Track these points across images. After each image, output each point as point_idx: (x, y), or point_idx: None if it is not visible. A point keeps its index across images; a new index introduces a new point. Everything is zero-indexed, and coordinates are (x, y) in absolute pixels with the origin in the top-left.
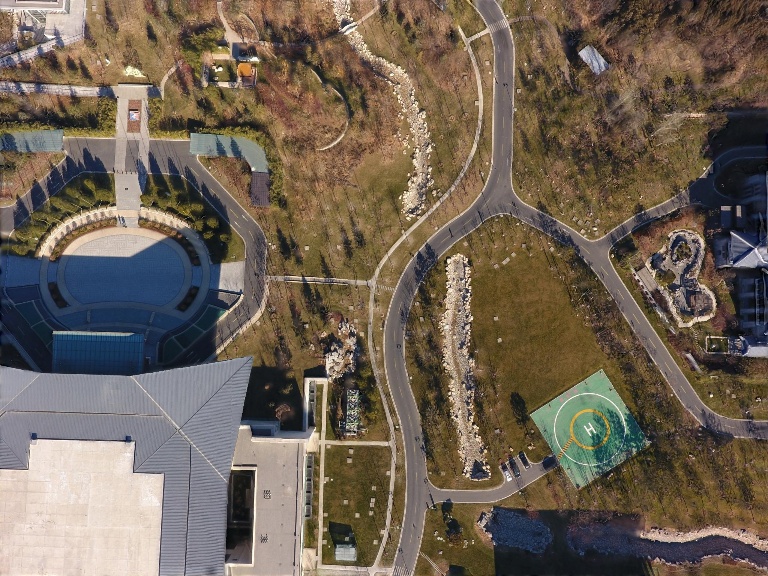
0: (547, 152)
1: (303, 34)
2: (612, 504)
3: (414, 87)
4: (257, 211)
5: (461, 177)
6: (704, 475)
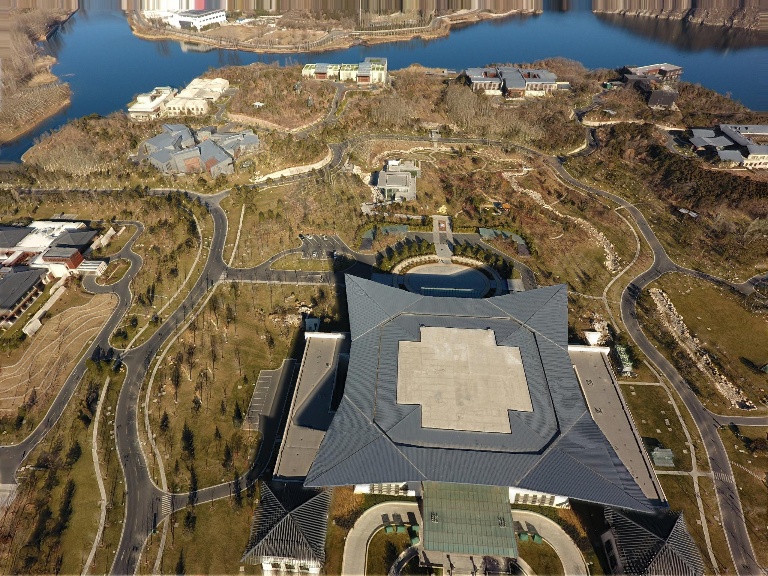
0: (684, 247)
1: None
2: None
3: (591, 225)
4: (523, 260)
5: (637, 256)
6: None
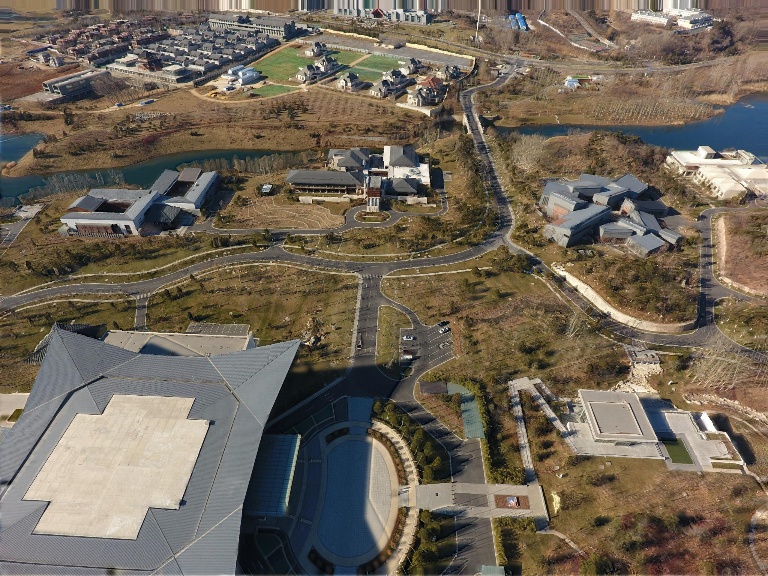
0: None
1: None
2: None
3: None
4: None
5: None
6: None
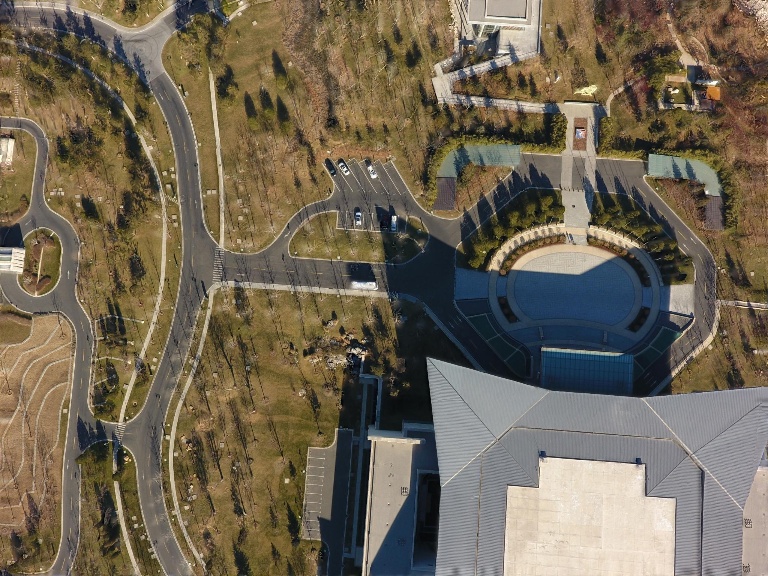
0: None
1: (741, 59)
2: None
3: None
4: (706, 234)
5: None
6: None
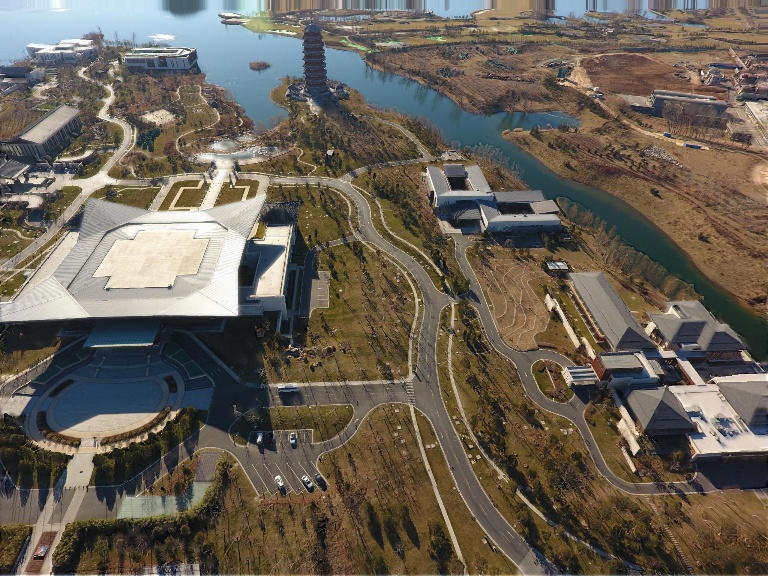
0: None
1: None
2: None
3: None
4: None
5: None
6: None
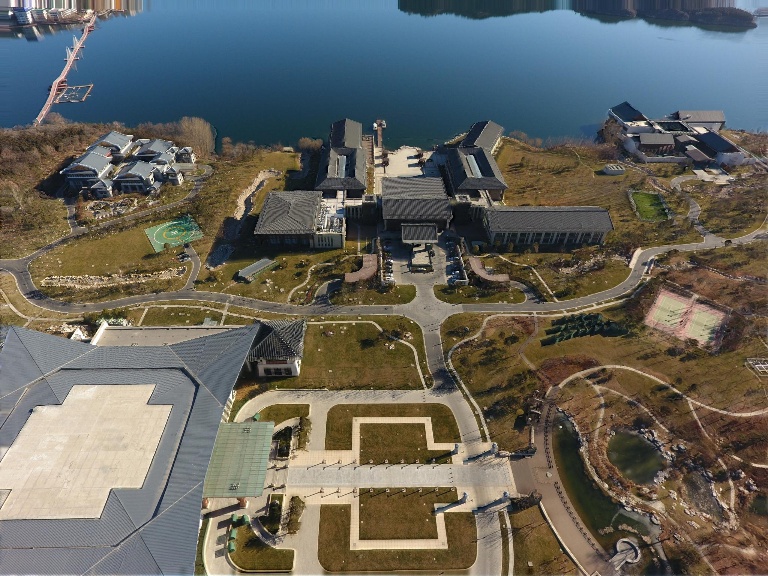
0: (4, 246)
1: None
2: (216, 226)
3: None
4: None
5: None
6: (212, 201)
